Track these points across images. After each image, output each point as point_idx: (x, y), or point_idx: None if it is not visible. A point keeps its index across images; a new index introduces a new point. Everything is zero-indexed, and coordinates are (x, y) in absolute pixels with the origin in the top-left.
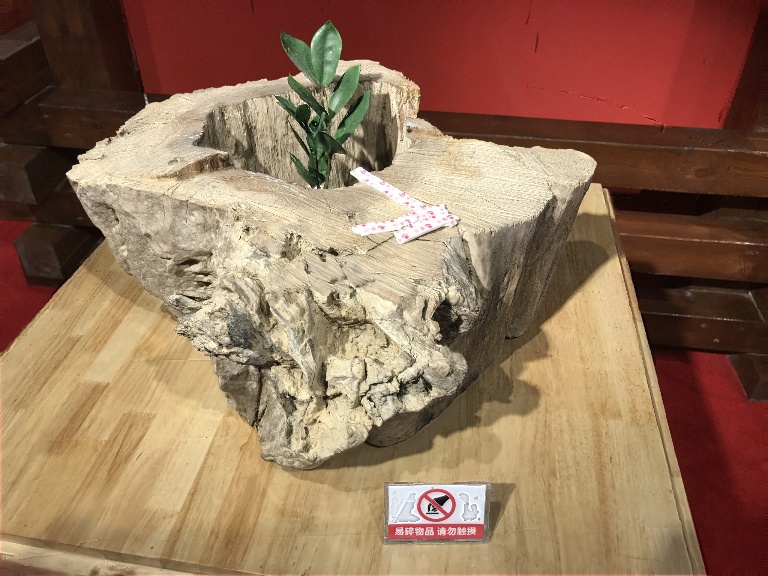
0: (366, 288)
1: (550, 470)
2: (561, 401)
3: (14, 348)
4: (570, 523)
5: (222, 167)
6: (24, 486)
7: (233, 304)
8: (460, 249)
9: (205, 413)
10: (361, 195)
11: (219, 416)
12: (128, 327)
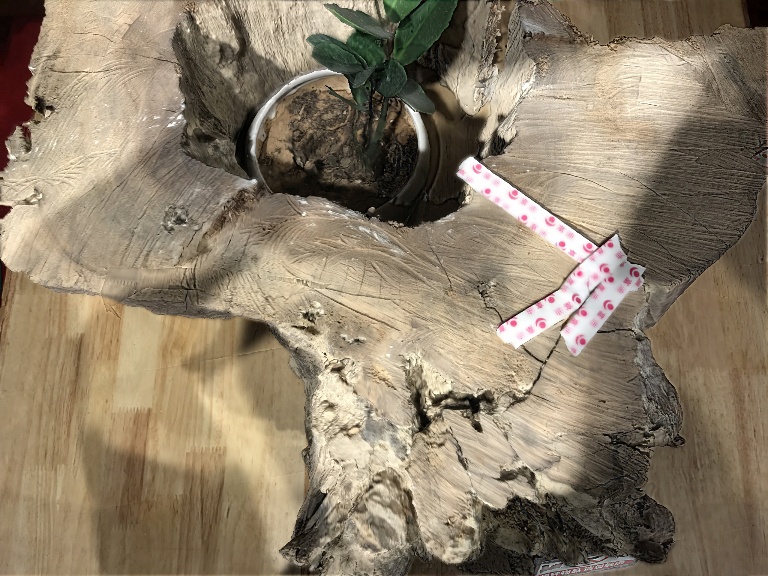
0: (550, 473)
1: (690, 458)
2: (696, 355)
3: (3, 368)
4: (715, 525)
5: (250, 200)
6: (114, 574)
7: (381, 559)
8: (643, 312)
9: (284, 437)
10: (486, 231)
11: (301, 439)
12: (137, 310)
